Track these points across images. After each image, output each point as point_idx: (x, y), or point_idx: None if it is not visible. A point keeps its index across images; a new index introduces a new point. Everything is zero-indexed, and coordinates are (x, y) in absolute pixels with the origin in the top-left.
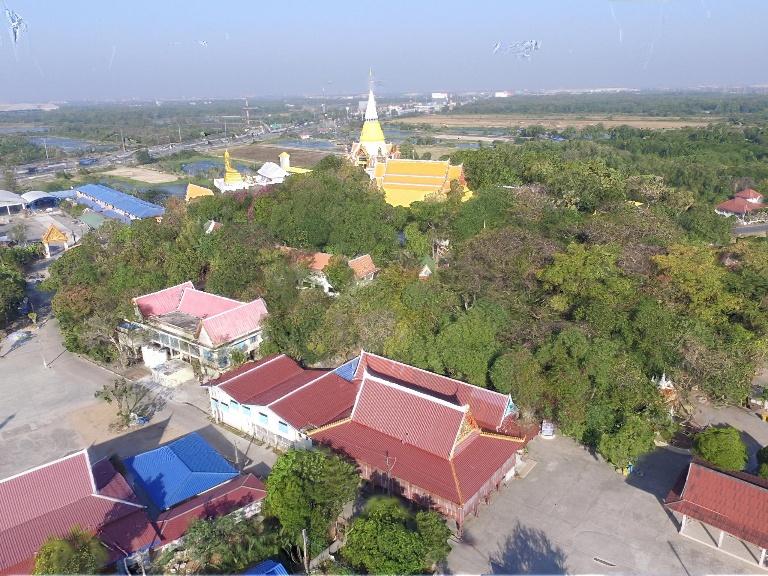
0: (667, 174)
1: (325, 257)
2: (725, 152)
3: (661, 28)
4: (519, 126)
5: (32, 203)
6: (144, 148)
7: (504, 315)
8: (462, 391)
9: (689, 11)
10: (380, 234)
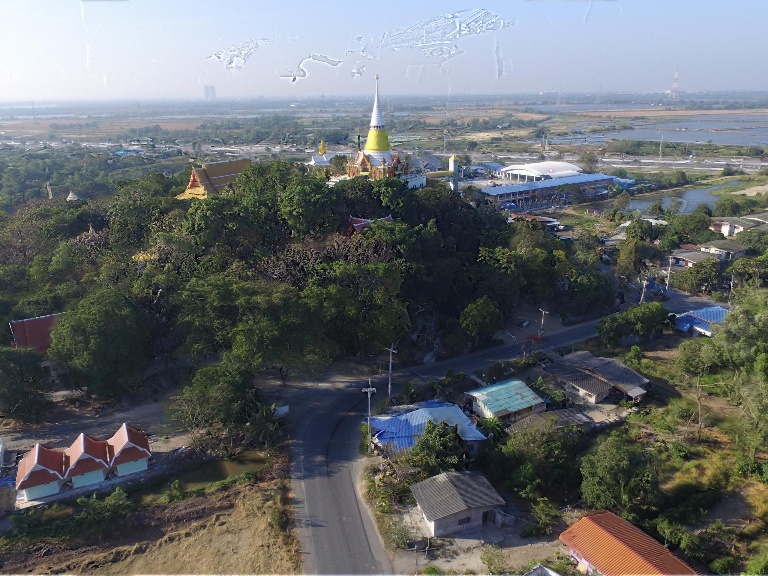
0: None
1: None
2: None
3: None
4: None
5: (546, 178)
6: None
7: None
8: None
9: None
10: None
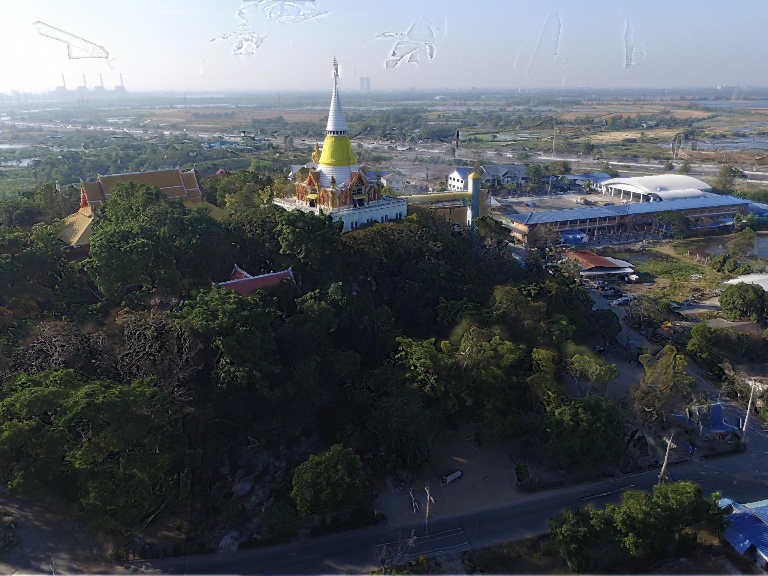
0: None
1: None
2: None
3: None
4: None
5: (655, 197)
6: None
7: None
8: None
9: None
10: None
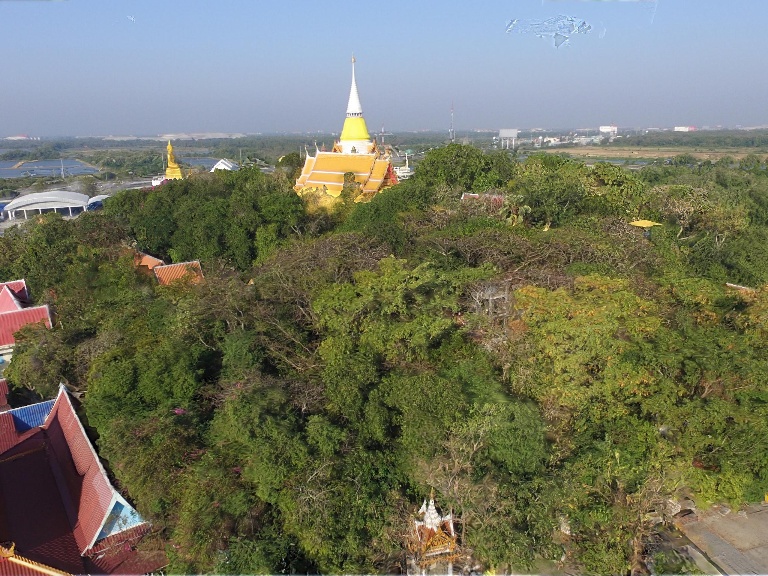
0: None
1: (149, 261)
2: None
3: None
4: (673, 157)
5: (92, 206)
6: (252, 165)
7: (246, 358)
8: (91, 472)
9: None
10: (226, 237)
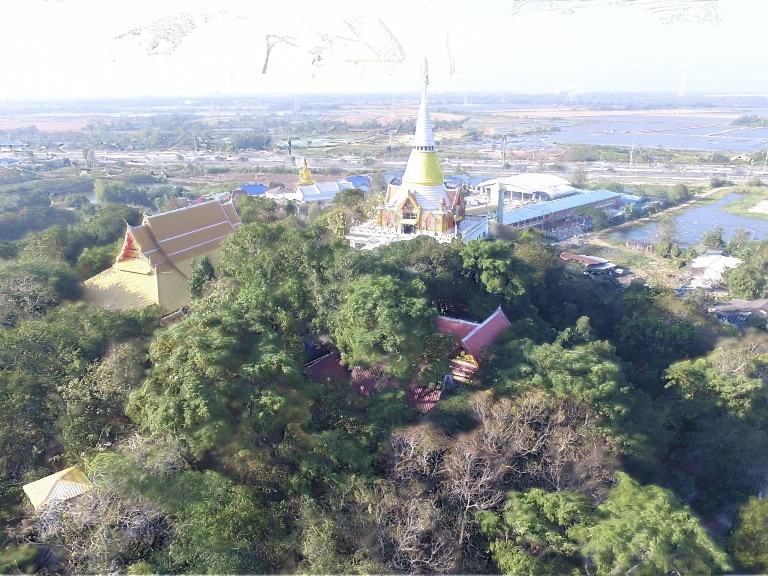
0: None
1: None
2: None
3: None
4: None
5: (538, 195)
6: None
7: None
8: None
9: None
10: None
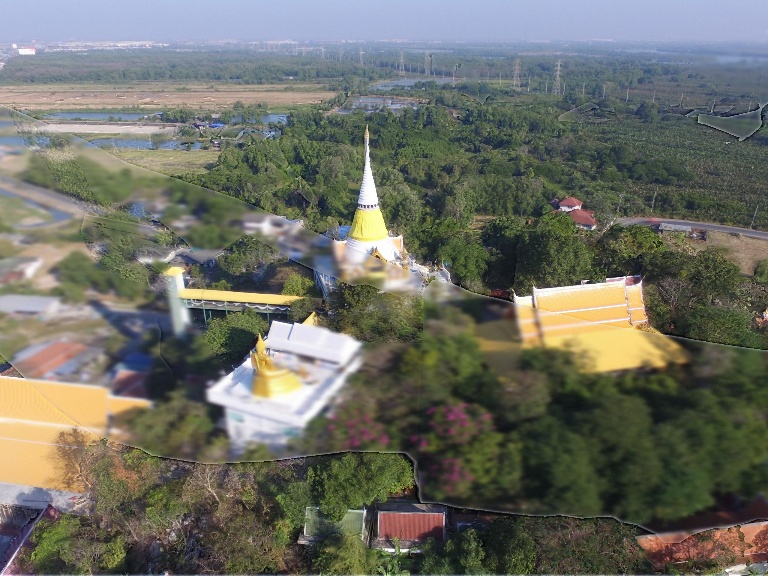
0: (492, 188)
1: None
2: (433, 140)
3: (759, 89)
4: (139, 106)
5: None
6: None
7: None
8: None
9: (735, 64)
10: None
